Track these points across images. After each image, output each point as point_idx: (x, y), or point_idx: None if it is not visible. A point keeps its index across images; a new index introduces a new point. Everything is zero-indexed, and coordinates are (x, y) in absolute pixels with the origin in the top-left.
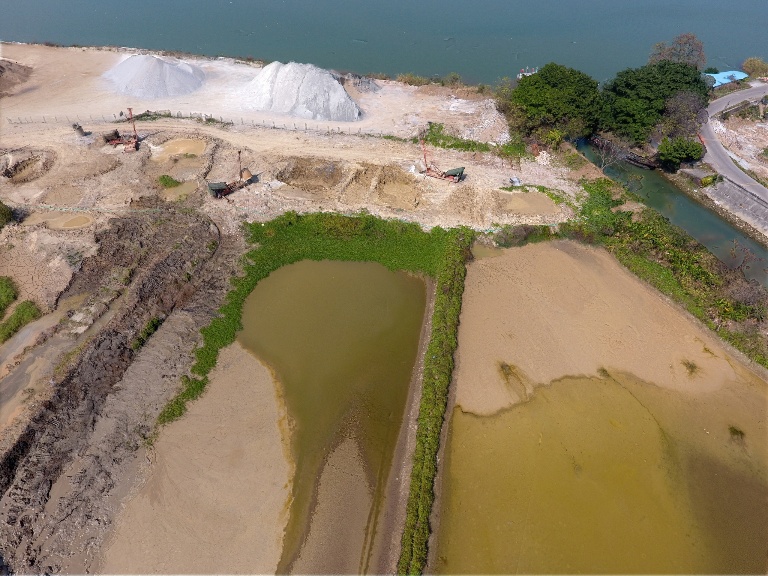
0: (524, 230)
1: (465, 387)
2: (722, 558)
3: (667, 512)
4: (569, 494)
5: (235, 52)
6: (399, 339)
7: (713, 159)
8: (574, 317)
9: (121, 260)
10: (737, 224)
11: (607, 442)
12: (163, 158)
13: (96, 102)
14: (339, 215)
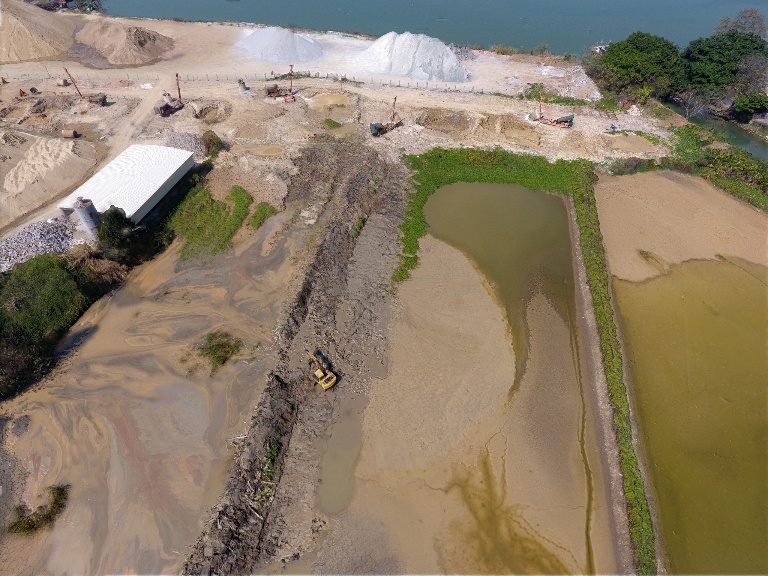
0: (634, 161)
1: (616, 264)
2: None
3: None
4: (713, 328)
5: (343, 27)
6: (554, 234)
7: None
8: (688, 222)
9: (319, 178)
10: None
11: (734, 299)
12: (318, 107)
13: (241, 65)
14: (479, 150)
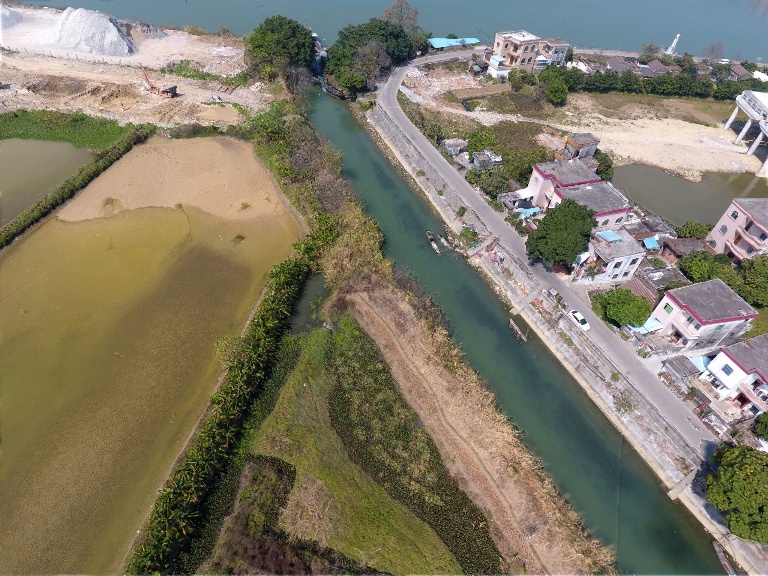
0: (193, 127)
1: (70, 208)
2: (163, 289)
3: (150, 269)
4: (92, 259)
5: (58, 3)
6: (47, 183)
7: (383, 91)
8: (188, 178)
9: None
10: (370, 134)
11: (144, 238)
12: None
13: None
14: (57, 112)
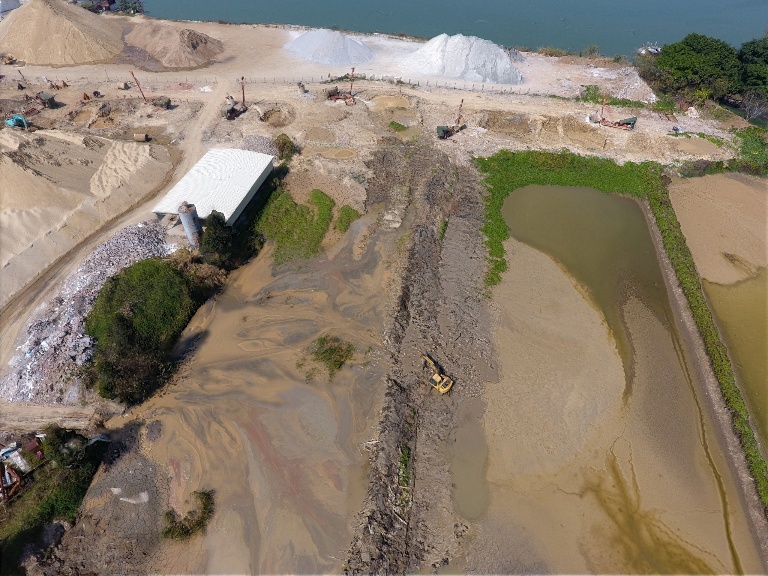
0: (703, 164)
1: (703, 267)
2: None
3: None
4: None
5: (388, 29)
6: (635, 237)
7: None
8: (766, 224)
9: (395, 181)
10: None
11: None
12: (380, 110)
13: (294, 68)
14: (546, 152)
